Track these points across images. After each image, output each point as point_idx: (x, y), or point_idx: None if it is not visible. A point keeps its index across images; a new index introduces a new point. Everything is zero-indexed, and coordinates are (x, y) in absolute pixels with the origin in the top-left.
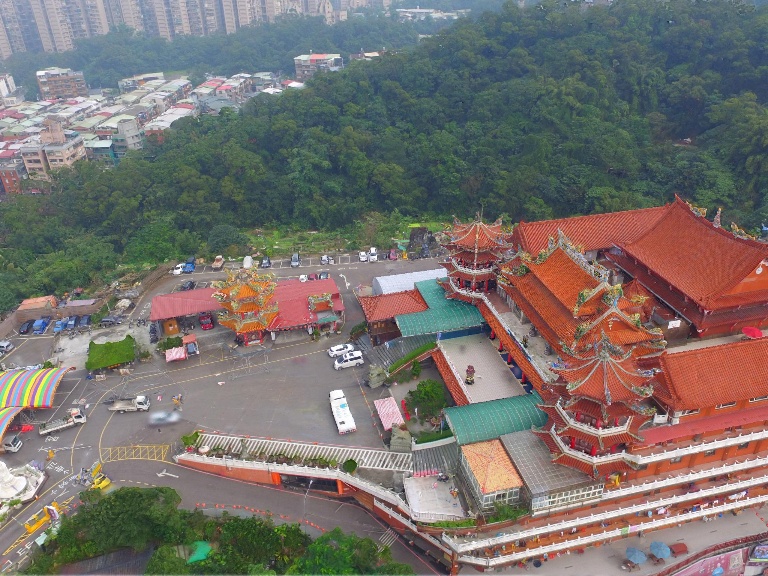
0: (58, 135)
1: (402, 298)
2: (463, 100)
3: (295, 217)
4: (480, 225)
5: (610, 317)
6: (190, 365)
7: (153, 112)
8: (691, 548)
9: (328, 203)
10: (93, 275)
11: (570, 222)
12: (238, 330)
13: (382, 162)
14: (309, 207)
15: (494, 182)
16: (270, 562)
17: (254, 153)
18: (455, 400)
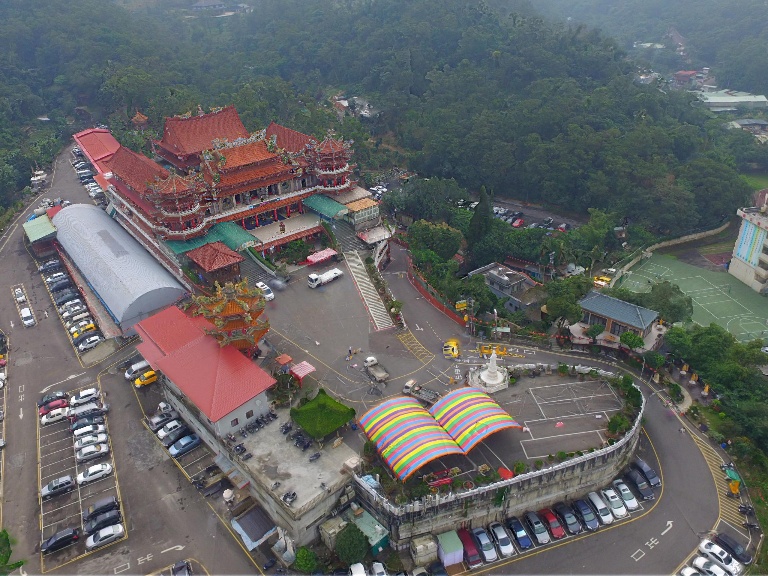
0: None
1: None
2: None
3: None
4: (177, 175)
5: None
6: None
7: None
8: None
9: None
10: None
11: None
12: (267, 327)
13: None
14: None
15: None
16: None
17: None
18: None
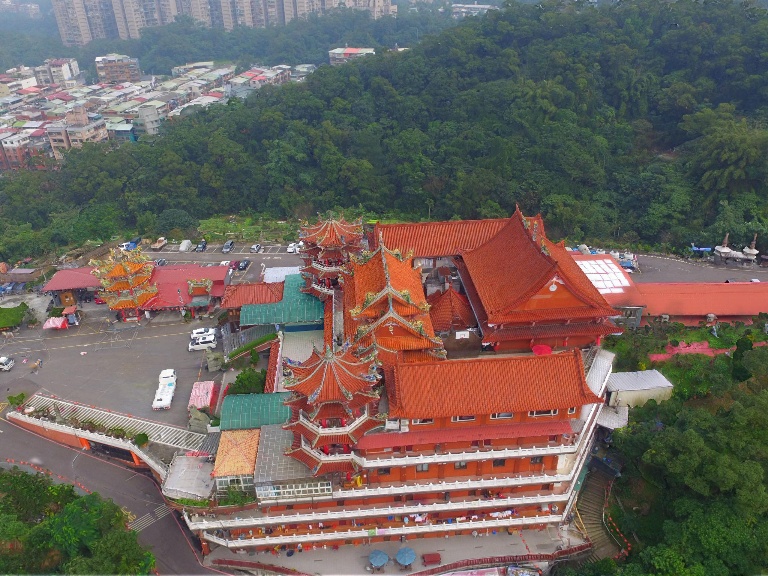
0: (81, 117)
1: (260, 289)
2: (448, 99)
3: (268, 206)
4: (332, 223)
5: (387, 321)
6: (68, 334)
7: (186, 99)
8: (446, 560)
9: (298, 195)
10: (44, 247)
11: (430, 226)
12: (111, 306)
13: (354, 157)
14: (280, 197)
15: (456, 183)
16: (41, 516)
17: (236, 142)
18: (264, 389)
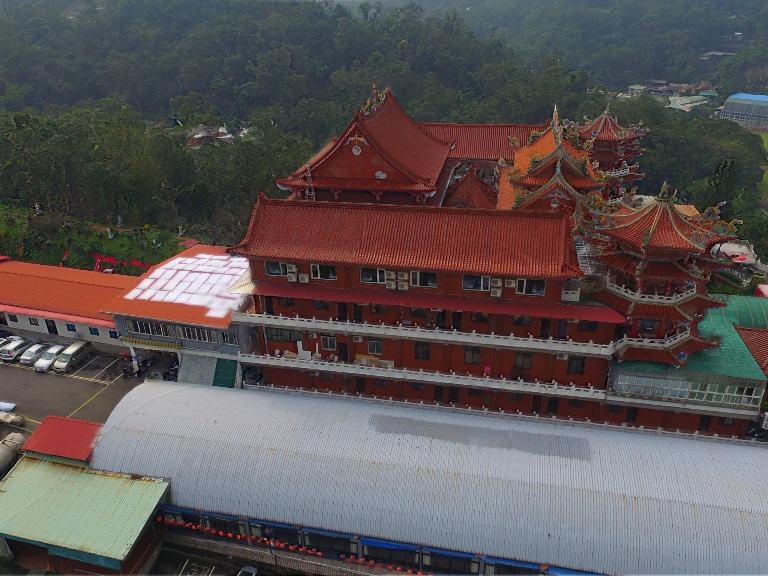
0: None
1: None
2: None
3: None
4: None
5: None
6: None
7: None
8: None
9: None
10: None
11: None
12: None
13: None
14: None
15: None
16: None
17: None
18: None
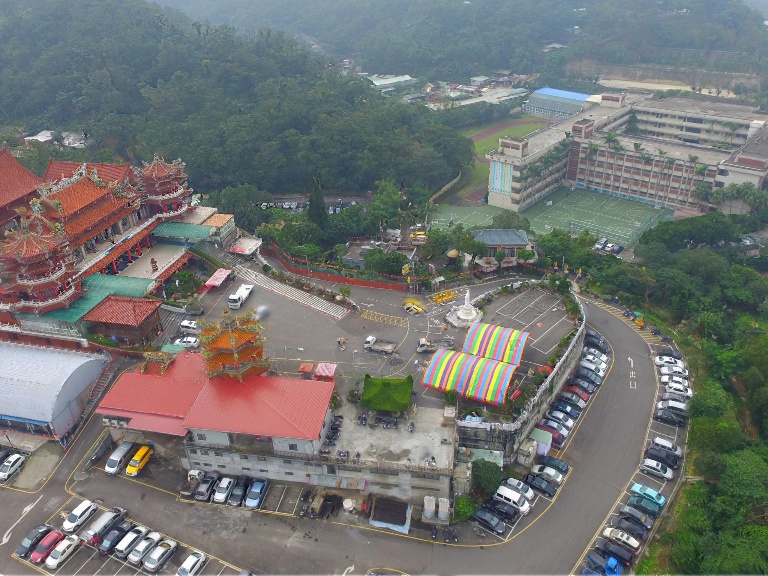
0: None
1: None
2: None
3: None
4: None
5: None
6: None
7: None
8: None
9: None
10: None
11: None
12: None
13: None
14: None
15: None
16: None
17: None
18: None
